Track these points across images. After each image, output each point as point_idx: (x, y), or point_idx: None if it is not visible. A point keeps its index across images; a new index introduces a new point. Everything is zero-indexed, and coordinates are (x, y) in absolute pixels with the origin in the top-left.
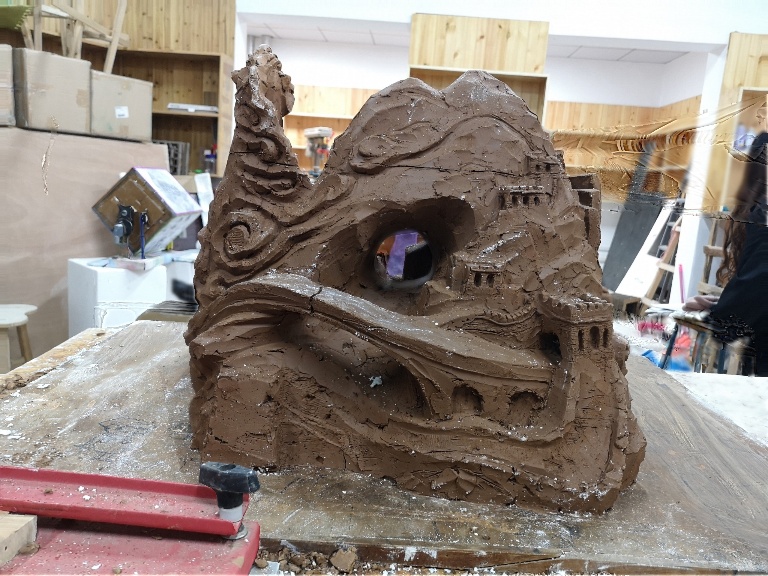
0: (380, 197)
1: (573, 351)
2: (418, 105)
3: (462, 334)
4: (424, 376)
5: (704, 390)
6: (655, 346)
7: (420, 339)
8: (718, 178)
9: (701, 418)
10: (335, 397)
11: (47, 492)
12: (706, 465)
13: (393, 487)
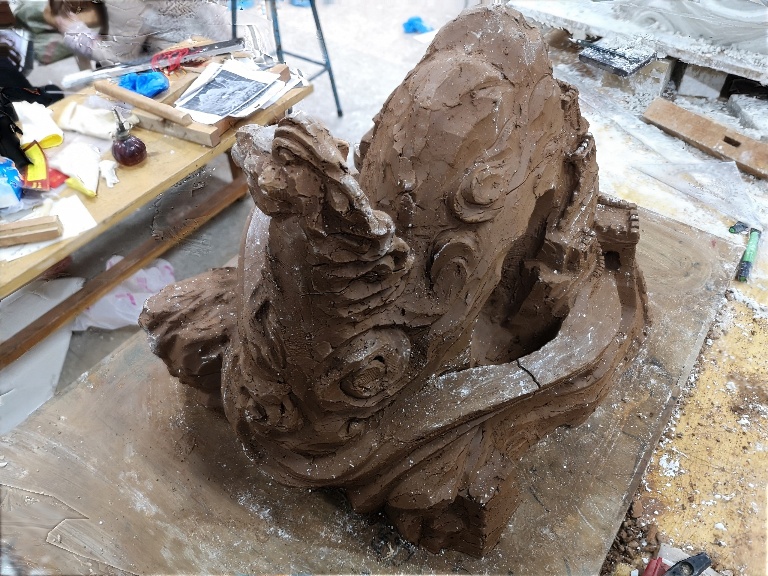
0: (510, 240)
1: None
2: (500, 106)
3: (590, 305)
4: None
5: None
6: (211, 8)
7: (606, 345)
8: None
9: None
10: None
11: None
12: None
13: (569, 430)
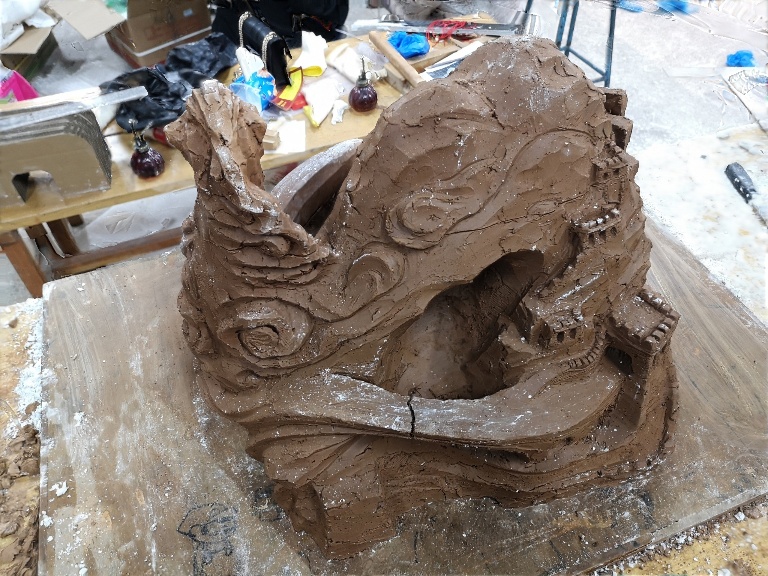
0: (444, 279)
1: (648, 372)
2: (468, 142)
3: (551, 391)
4: (529, 450)
5: (647, 186)
6: None
7: (530, 436)
8: (732, 34)
9: (670, 261)
10: (424, 455)
11: None
12: (699, 347)
13: (496, 507)
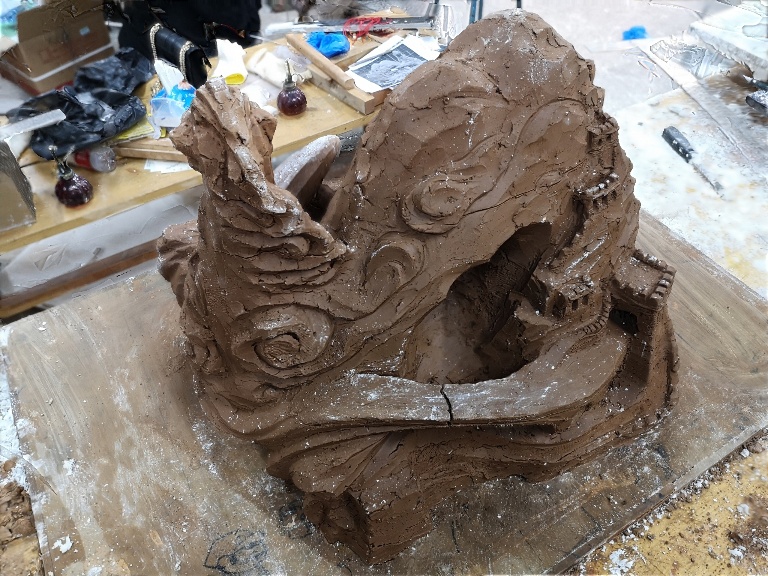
0: (464, 261)
1: None
2: (478, 119)
3: (570, 360)
4: None
5: None
6: None
7: (561, 405)
8: None
9: None
10: (451, 443)
11: None
12: (676, 301)
13: (524, 483)
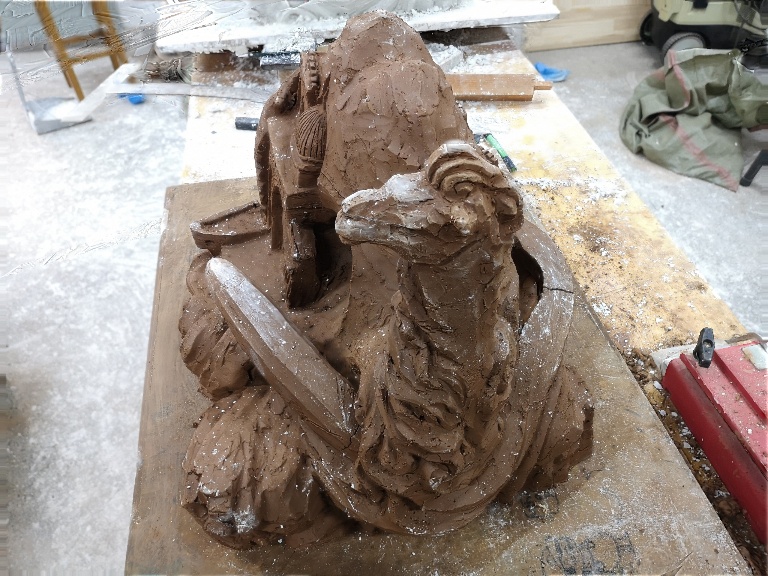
0: None
1: None
2: None
3: None
4: None
5: (231, 171)
6: None
7: None
8: None
9: None
10: None
11: (767, 454)
12: None
13: None
